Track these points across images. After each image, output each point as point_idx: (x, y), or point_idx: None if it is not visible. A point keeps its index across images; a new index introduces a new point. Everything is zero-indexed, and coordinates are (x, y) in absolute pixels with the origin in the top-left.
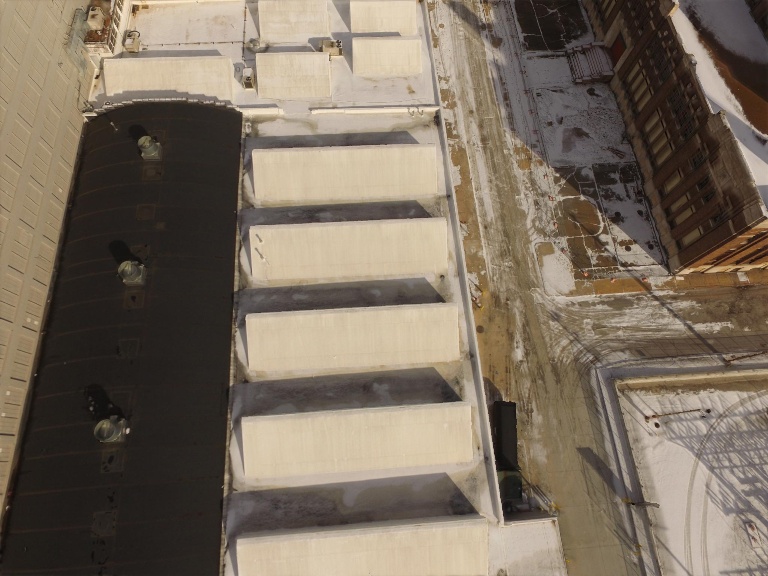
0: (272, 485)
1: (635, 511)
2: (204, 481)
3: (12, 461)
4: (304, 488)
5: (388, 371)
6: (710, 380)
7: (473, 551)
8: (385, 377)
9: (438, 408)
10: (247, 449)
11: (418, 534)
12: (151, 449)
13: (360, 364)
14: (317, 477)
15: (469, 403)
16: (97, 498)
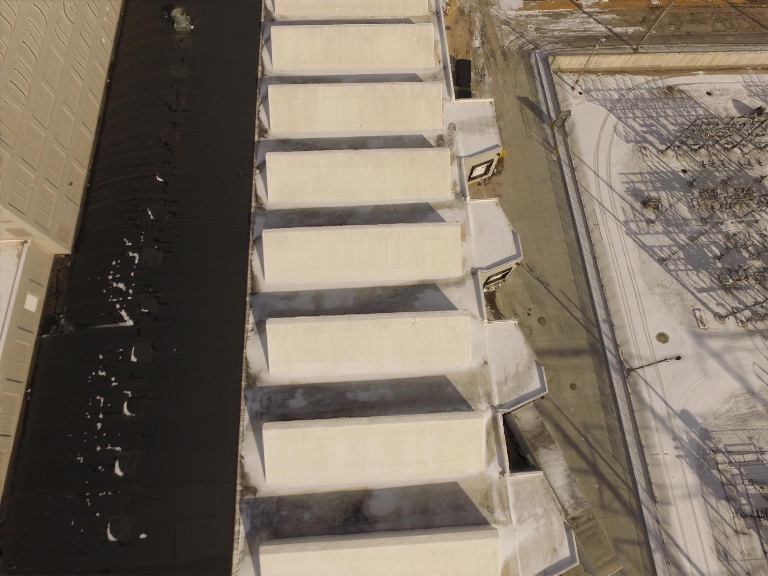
0: (292, 74)
1: (557, 131)
2: (245, 64)
3: (110, 56)
4: (314, 76)
5: (376, 19)
6: (624, 68)
7: (431, 104)
8: (373, 22)
9: (410, 26)
10: (274, 48)
11: (393, 88)
12: (208, 38)
13: (355, 14)
14: (323, 71)
15: (432, 24)
16: (173, 59)
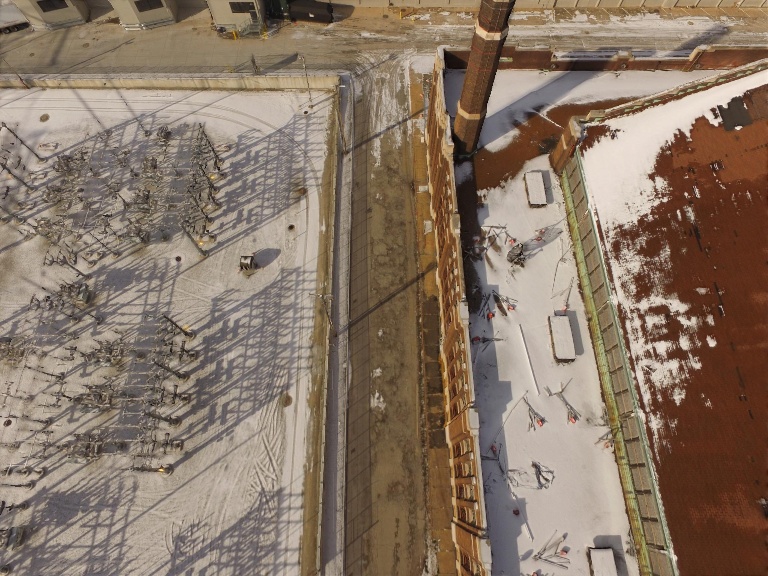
0: None
1: (252, 74)
2: None
3: None
4: None
5: None
6: None
7: None
8: None
9: None
10: None
11: None
12: None
13: None
14: None
15: None
16: None
